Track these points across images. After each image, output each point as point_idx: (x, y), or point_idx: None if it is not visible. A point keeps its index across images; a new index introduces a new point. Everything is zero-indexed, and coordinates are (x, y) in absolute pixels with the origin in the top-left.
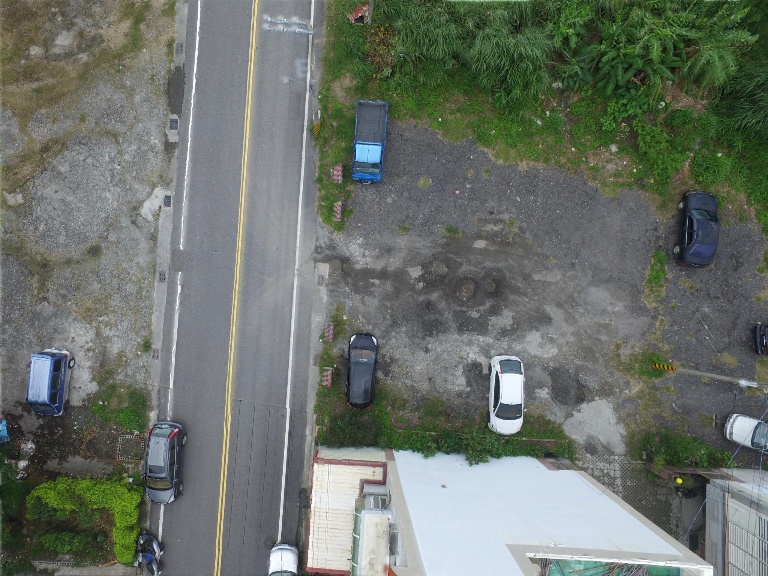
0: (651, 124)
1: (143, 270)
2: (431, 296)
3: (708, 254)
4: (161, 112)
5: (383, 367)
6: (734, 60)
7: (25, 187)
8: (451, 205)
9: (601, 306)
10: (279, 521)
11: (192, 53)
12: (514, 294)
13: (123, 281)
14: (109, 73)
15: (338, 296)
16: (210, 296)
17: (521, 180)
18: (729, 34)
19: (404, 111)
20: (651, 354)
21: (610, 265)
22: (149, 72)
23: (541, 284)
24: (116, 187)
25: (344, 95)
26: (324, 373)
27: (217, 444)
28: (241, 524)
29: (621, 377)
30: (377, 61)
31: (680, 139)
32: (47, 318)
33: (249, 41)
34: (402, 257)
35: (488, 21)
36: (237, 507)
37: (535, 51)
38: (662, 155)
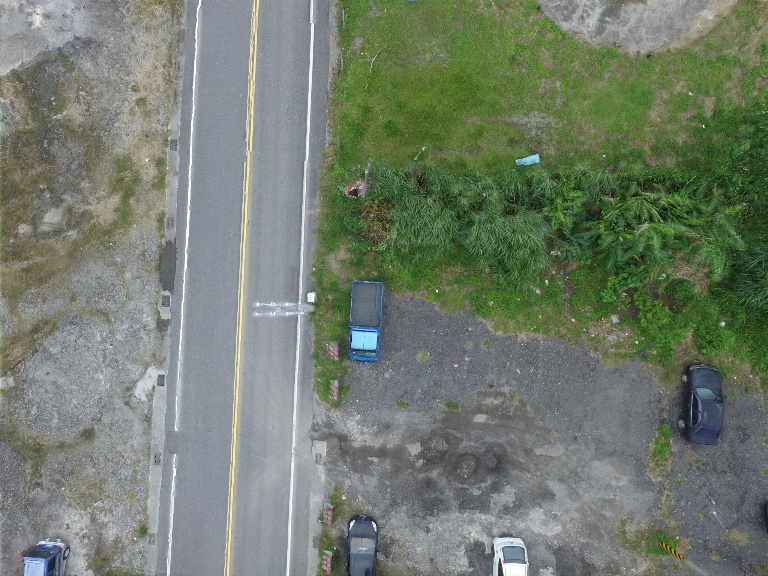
0: (653, 293)
1: (137, 452)
2: (431, 473)
3: (714, 435)
4: (153, 289)
5: (384, 548)
6: (736, 227)
7: (16, 370)
8: (450, 379)
9: (605, 481)
10: None
11: (183, 227)
12: (516, 470)
13: (117, 465)
14: (99, 250)
15: (336, 475)
16: (206, 479)
17: (521, 352)
18: (730, 197)
19: (400, 282)
20: (657, 531)
21: (614, 438)
22: (140, 248)
23: (543, 459)
24: (108, 368)
25: (339, 267)
26: (324, 556)
27: None
28: None
29: (627, 555)
30: (371, 236)
31: (683, 315)
32: (41, 505)
33: (241, 215)
34: (401, 433)
35: (484, 205)
36: None
37: (532, 238)
38: (665, 330)
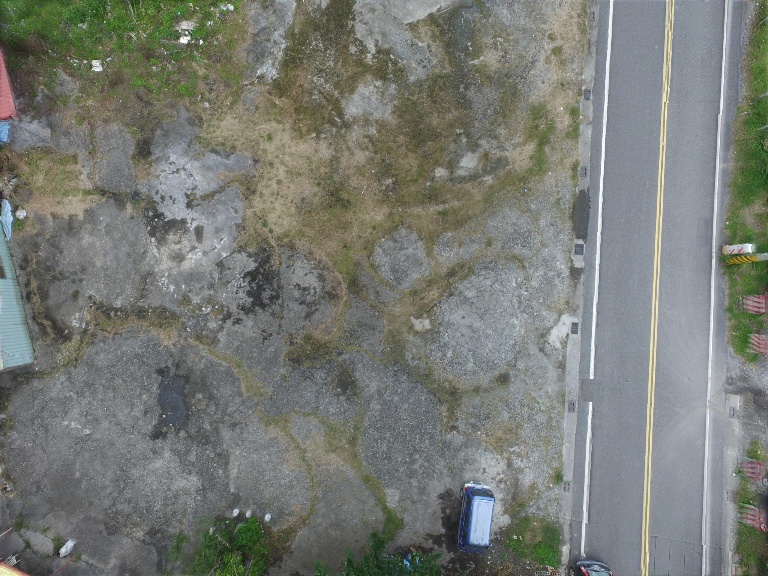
0: None
1: (552, 399)
2: None
3: None
4: (566, 236)
5: None
6: None
7: (432, 312)
8: None
9: None
10: None
11: (597, 176)
12: None
13: (533, 411)
14: (515, 196)
15: (751, 429)
16: (622, 428)
17: None
18: None
19: None
20: None
21: None
22: (555, 196)
23: None
24: (524, 314)
25: (752, 221)
26: (741, 510)
27: None
28: None
29: None
30: None
31: None
32: (457, 448)
33: (657, 166)
34: None
35: None
36: None
37: None
38: None
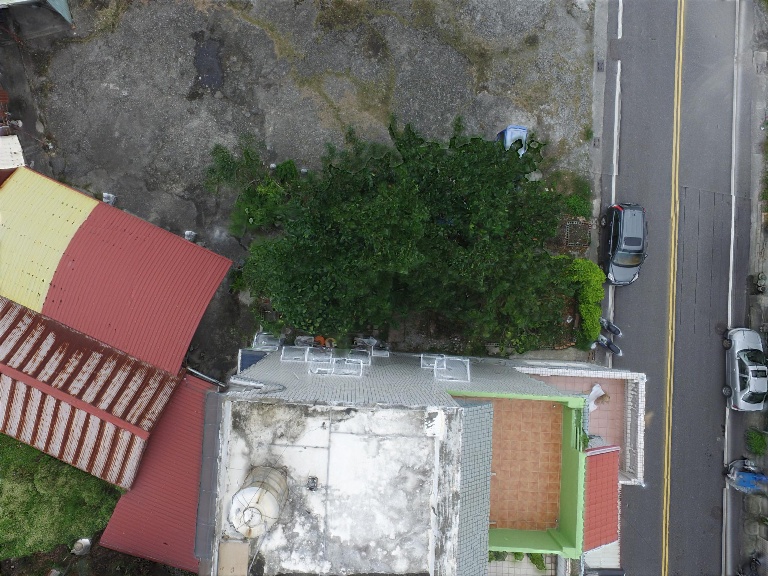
0: None
1: (581, 59)
2: None
3: None
4: None
5: None
6: None
7: None
8: None
9: None
10: (728, 308)
11: None
12: None
13: (562, 70)
14: None
15: None
16: (651, 84)
17: None
18: None
19: None
20: None
21: None
22: None
23: None
24: None
25: None
26: None
27: (664, 230)
28: (691, 310)
29: None
30: None
31: None
32: (488, 107)
33: None
34: None
35: None
36: (687, 293)
37: None
38: None
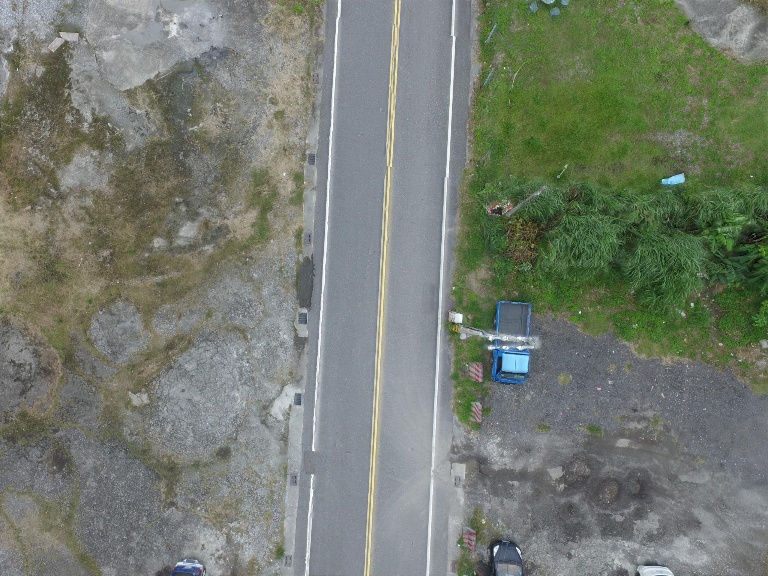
0: None
1: (274, 472)
2: (573, 499)
3: None
4: (289, 305)
5: (524, 574)
6: None
7: (151, 386)
8: (593, 402)
9: (751, 509)
10: None
11: (321, 243)
12: (660, 496)
13: (253, 485)
14: (236, 266)
15: (476, 499)
16: (344, 500)
17: (665, 376)
18: None
19: (542, 303)
20: None
21: (760, 466)
22: (277, 264)
23: (688, 486)
24: (245, 385)
25: (479, 286)
26: None
27: None
28: None
29: None
30: (517, 255)
31: None
32: (176, 524)
33: (381, 231)
34: (542, 457)
35: (642, 226)
36: None
37: (695, 262)
38: None
